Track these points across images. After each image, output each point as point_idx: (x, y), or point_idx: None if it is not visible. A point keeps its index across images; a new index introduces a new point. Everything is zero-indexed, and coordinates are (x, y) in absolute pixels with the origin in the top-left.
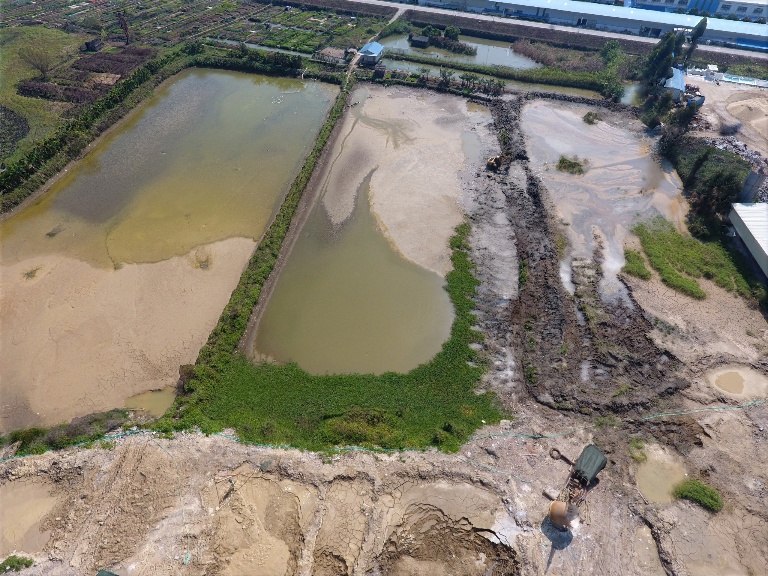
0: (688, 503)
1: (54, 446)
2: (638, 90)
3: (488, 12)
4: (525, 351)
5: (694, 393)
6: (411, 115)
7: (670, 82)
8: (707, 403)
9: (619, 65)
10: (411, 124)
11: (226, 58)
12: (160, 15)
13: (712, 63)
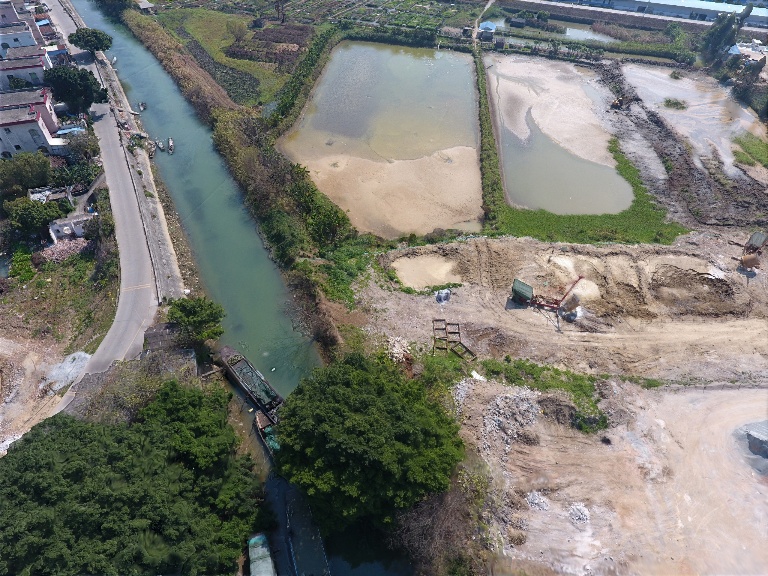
0: None
1: (431, 241)
2: (702, 58)
3: (563, 1)
4: (688, 202)
5: None
6: (537, 74)
7: (730, 50)
8: None
9: (684, 40)
10: (540, 80)
11: (374, 33)
12: (291, 1)
13: (755, 39)
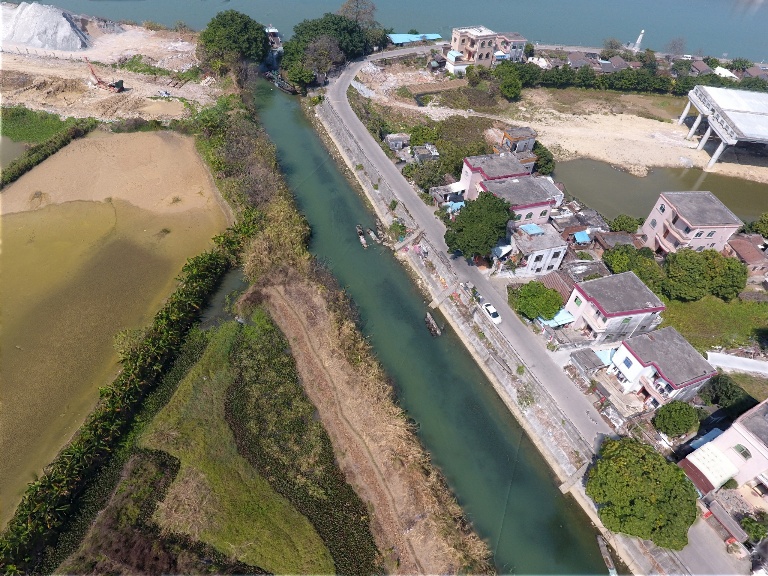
0: None
1: None
2: None
3: None
4: None
5: None
6: None
7: None
8: None
9: None
10: None
11: None
12: None
13: None
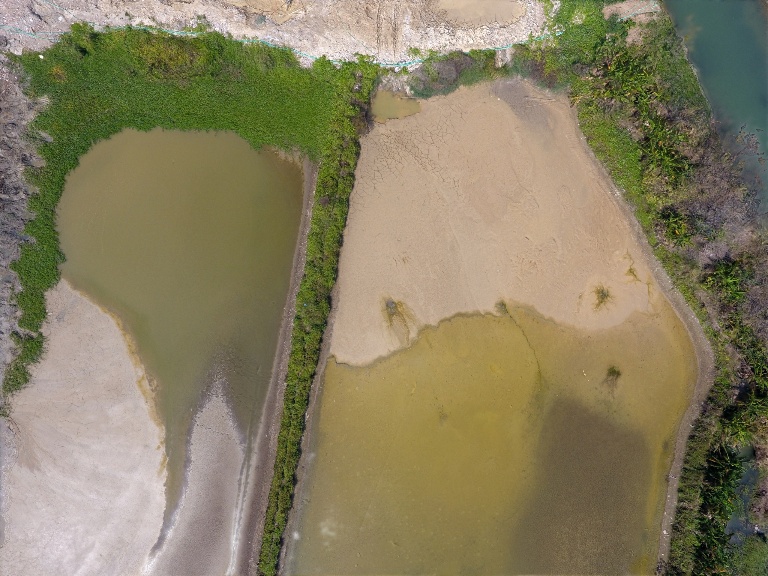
0: None
1: None
2: None
3: None
4: None
5: None
6: None
7: None
8: None
9: None
10: None
11: None
12: None
13: None
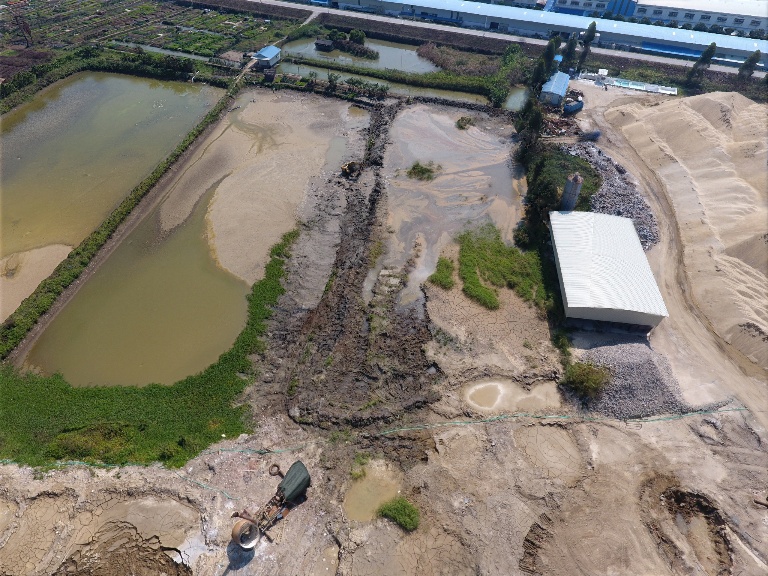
0: (385, 522)
1: None
2: (526, 95)
3: (403, 15)
4: (298, 362)
5: (441, 407)
6: (288, 120)
7: (551, 87)
8: (451, 417)
9: (512, 69)
10: (284, 129)
11: (119, 62)
12: (74, 18)
13: None
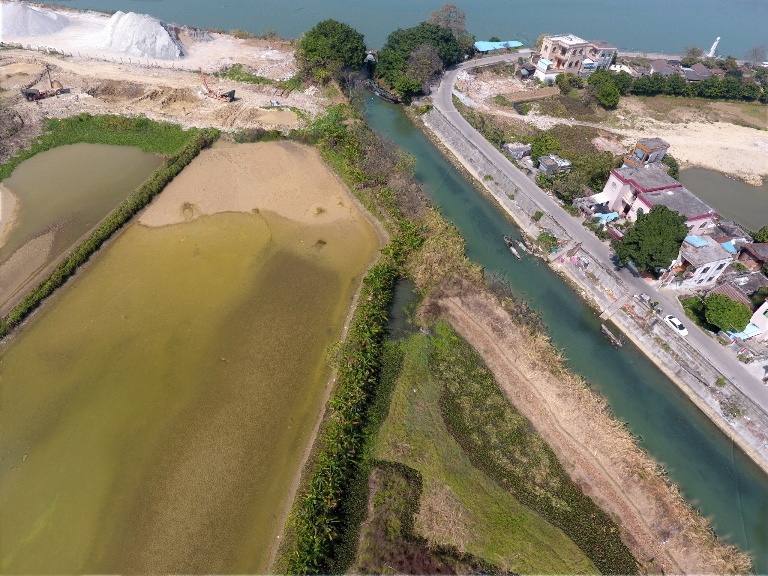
0: (4, 88)
1: None
2: None
3: None
4: (1, 138)
5: None
6: None
7: None
8: None
9: None
10: None
11: None
12: None
13: None
